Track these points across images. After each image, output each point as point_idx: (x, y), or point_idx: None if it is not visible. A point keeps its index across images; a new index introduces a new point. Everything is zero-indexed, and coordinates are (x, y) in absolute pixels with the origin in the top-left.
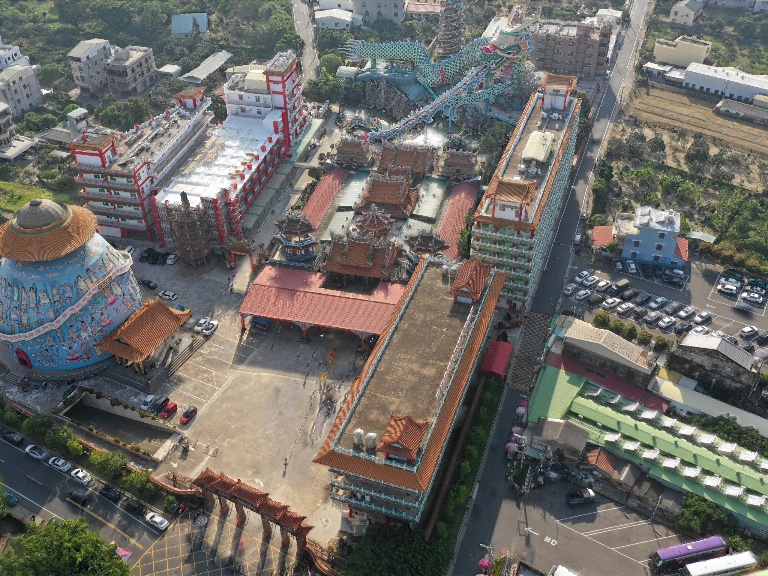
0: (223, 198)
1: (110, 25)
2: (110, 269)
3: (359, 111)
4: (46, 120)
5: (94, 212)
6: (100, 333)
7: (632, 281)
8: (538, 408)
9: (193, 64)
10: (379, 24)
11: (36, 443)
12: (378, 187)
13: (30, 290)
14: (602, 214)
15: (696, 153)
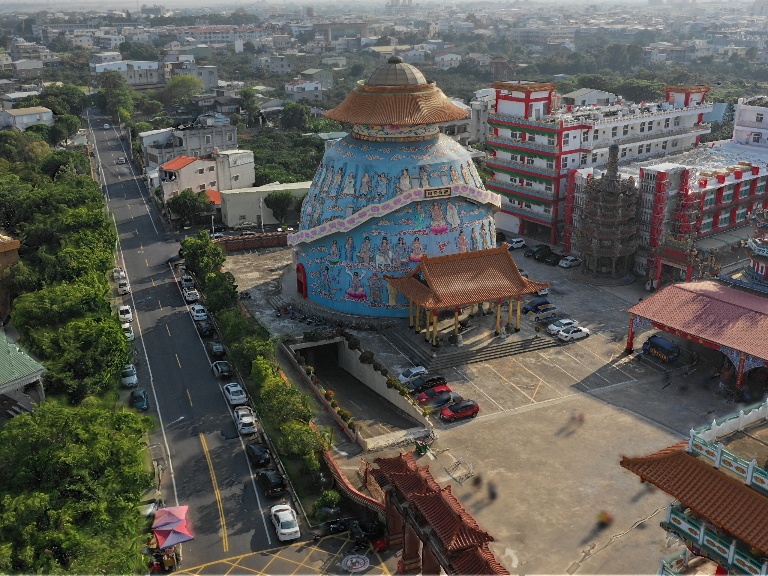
0: (675, 180)
1: None
2: None
3: None
4: None
5: (496, 189)
6: (403, 269)
7: None
8: None
9: (710, 137)
10: None
11: (233, 363)
12: None
13: (338, 171)
14: None
15: None
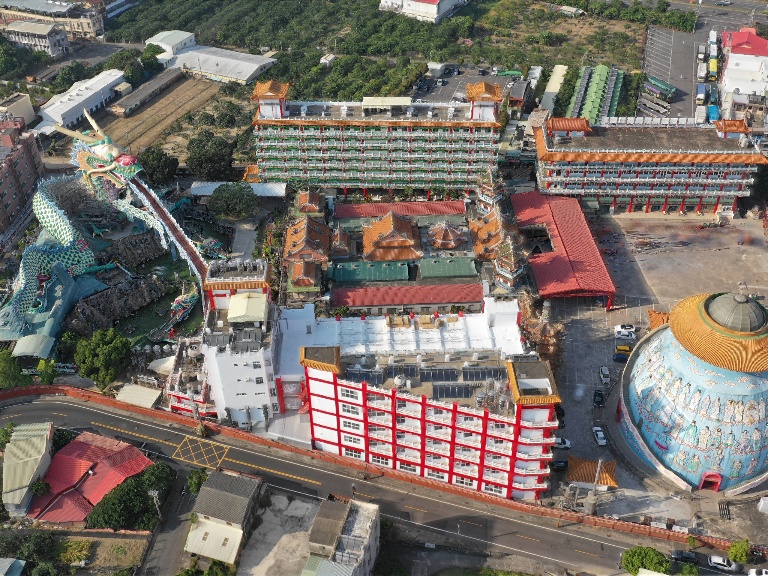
0: None
1: None
2: None
3: None
4: None
5: None
6: None
7: None
8: None
9: None
10: None
11: None
12: (399, 231)
13: None
14: None
15: (229, 116)
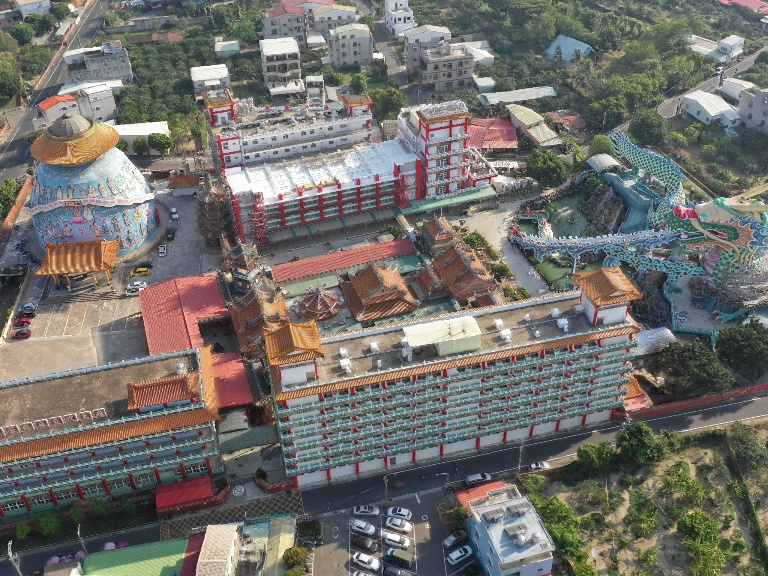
0: (246, 199)
1: (511, 23)
2: (93, 196)
3: (567, 209)
4: (333, 77)
5: None
6: (62, 239)
7: (432, 567)
8: (109, 557)
9: (505, 86)
10: (748, 135)
11: None
12: (368, 275)
13: None
14: (563, 483)
15: None
